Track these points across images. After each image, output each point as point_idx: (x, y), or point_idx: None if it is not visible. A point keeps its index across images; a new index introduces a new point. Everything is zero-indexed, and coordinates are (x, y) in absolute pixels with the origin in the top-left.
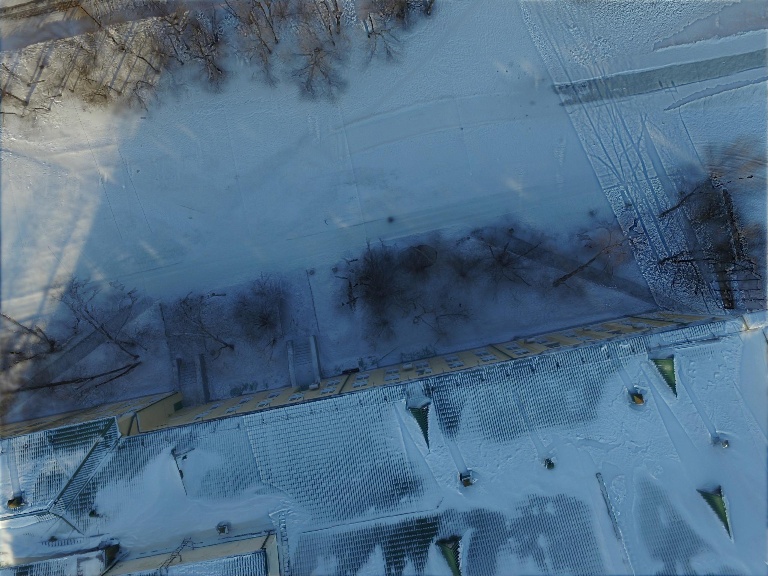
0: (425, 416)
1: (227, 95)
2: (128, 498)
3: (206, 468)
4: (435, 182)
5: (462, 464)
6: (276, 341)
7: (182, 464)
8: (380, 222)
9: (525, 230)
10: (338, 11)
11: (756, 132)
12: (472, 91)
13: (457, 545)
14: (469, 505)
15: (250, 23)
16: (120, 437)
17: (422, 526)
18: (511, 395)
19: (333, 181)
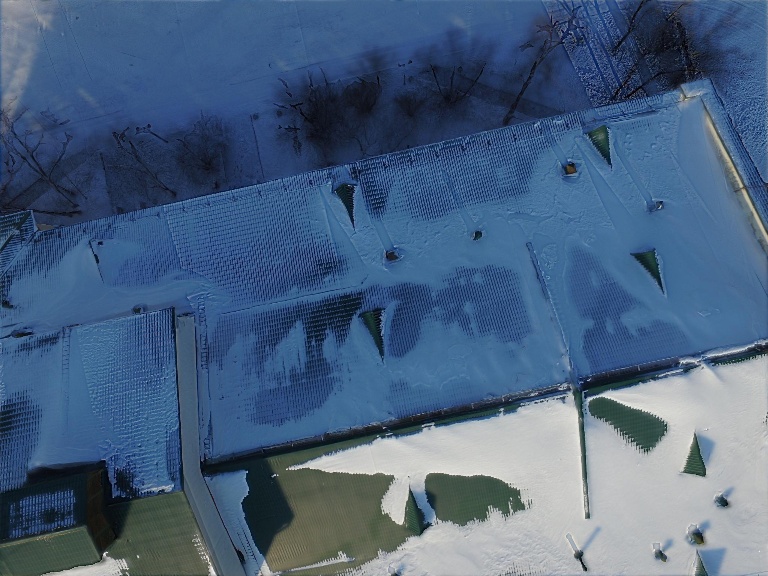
0: (350, 194)
1: None
2: (43, 289)
3: (124, 257)
4: (381, 23)
5: (388, 242)
6: (219, 187)
7: (97, 249)
8: (325, 64)
9: (474, 68)
10: None
11: None
12: None
13: (380, 314)
14: (395, 280)
15: None
16: (37, 231)
17: (345, 301)
18: (440, 174)
19: (277, 24)
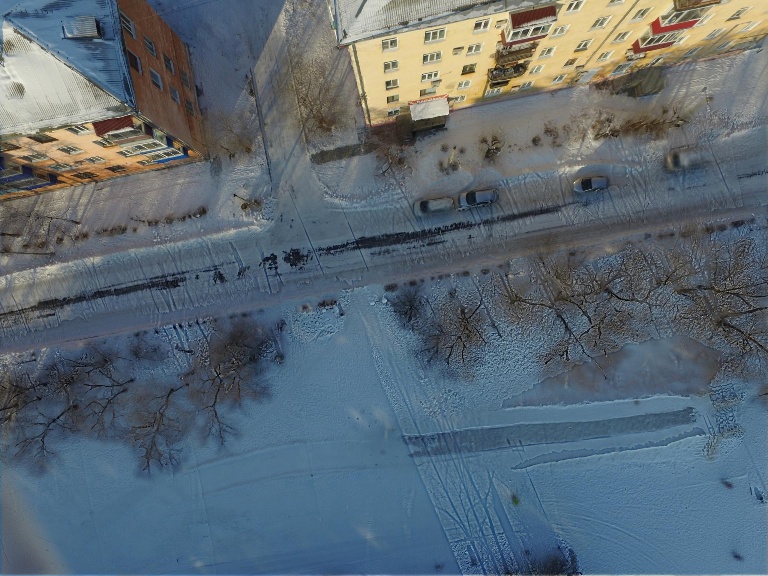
0: None
1: (83, 431)
2: None
3: None
4: (285, 526)
5: None
6: None
7: None
8: (230, 564)
9: None
10: (193, 351)
11: (603, 493)
12: (323, 437)
13: None
14: None
15: (105, 362)
16: None
17: None
18: None
19: (186, 519)
